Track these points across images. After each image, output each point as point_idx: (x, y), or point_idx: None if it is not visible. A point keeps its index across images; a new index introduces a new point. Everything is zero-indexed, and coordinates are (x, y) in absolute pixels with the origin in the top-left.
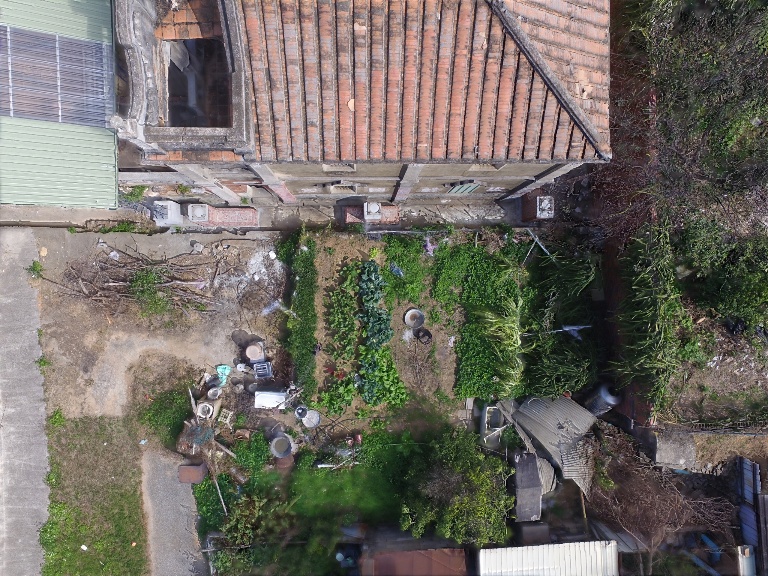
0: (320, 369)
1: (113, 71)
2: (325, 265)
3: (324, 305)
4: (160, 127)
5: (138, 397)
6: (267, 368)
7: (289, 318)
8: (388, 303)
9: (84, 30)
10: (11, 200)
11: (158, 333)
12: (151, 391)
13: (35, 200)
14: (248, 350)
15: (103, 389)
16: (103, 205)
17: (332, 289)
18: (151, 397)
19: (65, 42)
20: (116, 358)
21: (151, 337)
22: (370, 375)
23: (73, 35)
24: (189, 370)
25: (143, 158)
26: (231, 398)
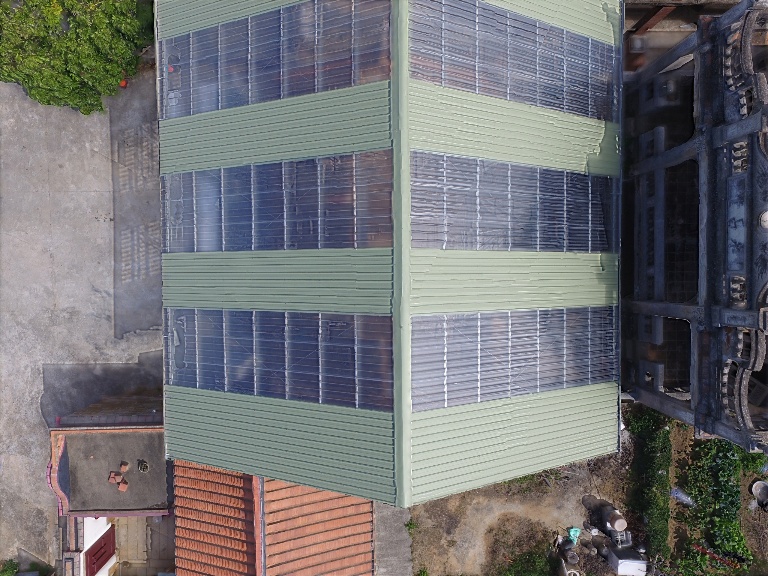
0: (671, 535)
1: (619, 329)
2: (677, 439)
3: (676, 476)
4: (763, 432)
5: (499, 558)
6: (625, 536)
7: (658, 495)
8: (736, 475)
9: (603, 297)
10: (563, 463)
11: (515, 498)
12: (510, 553)
13: (575, 458)
14: (617, 523)
15: (464, 550)
16: (611, 451)
17: (685, 462)
18: (510, 558)
19: (593, 311)
20: (477, 521)
21: (509, 502)
22: (726, 546)
23: (597, 304)
24: (545, 533)
25: (697, 434)
26: (580, 558)
